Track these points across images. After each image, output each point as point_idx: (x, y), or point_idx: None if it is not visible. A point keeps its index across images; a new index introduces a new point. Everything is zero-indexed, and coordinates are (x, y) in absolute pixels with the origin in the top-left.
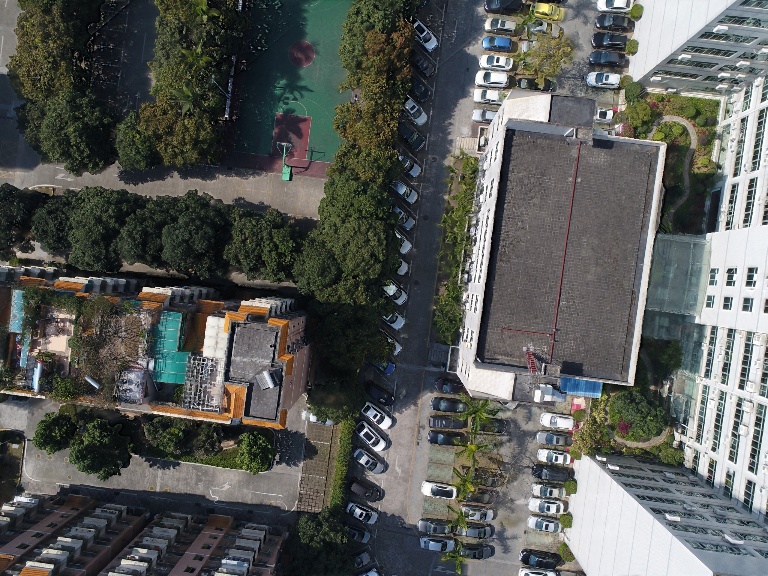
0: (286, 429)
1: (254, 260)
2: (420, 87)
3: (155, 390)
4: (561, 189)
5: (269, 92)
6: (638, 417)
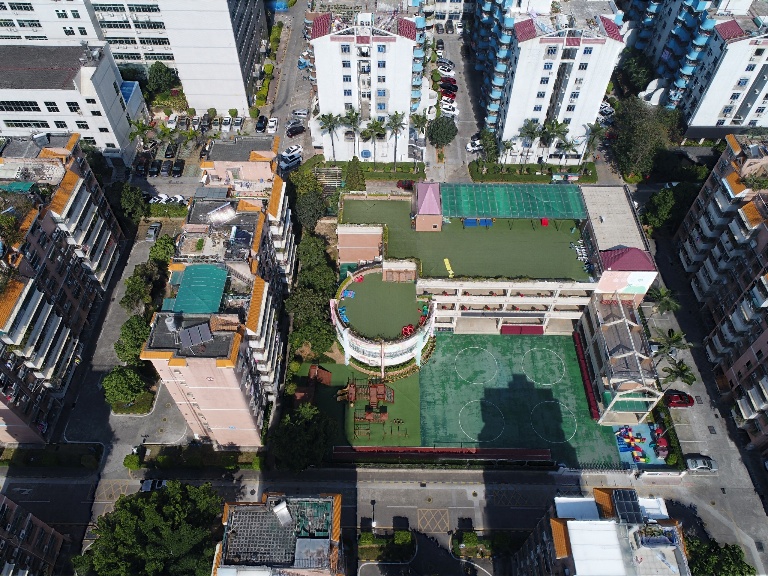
0: None
1: None
2: None
3: None
4: None
5: None
6: None
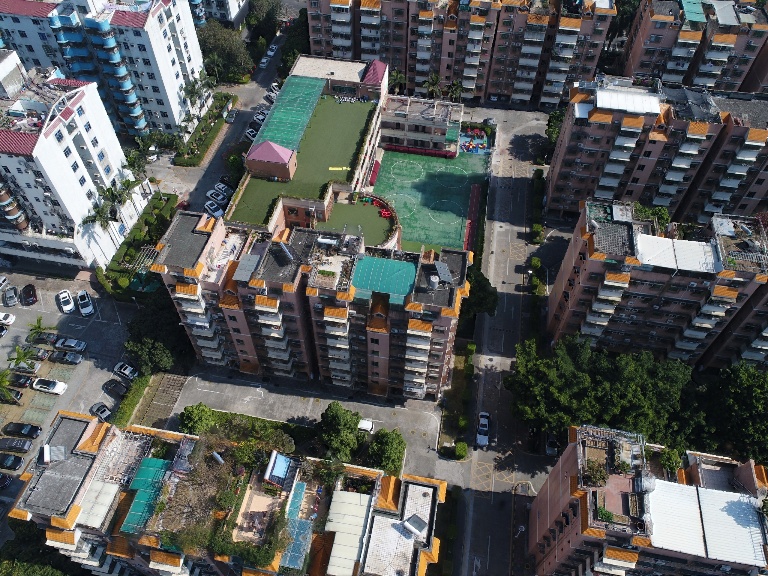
0: None
1: None
2: None
3: None
4: None
5: None
6: None
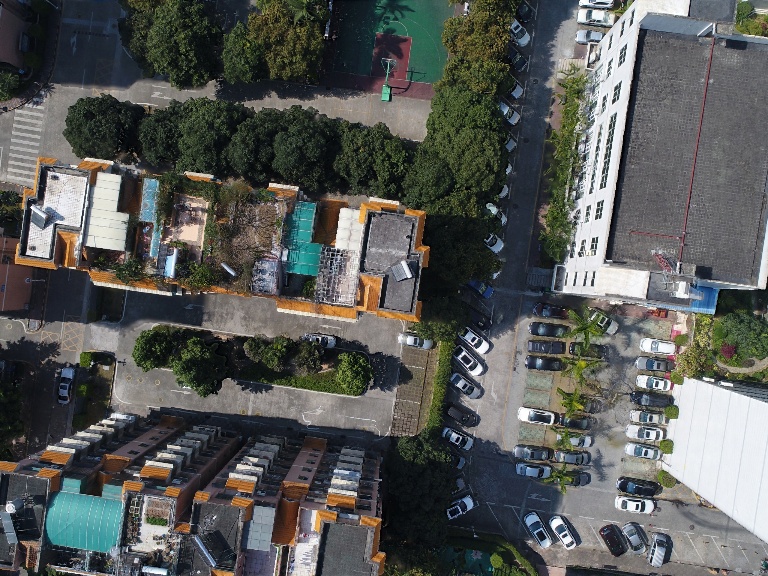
0: (381, 353)
1: (366, 170)
2: (524, 7)
3: (282, 286)
4: (693, 90)
5: (369, 11)
6: (752, 334)
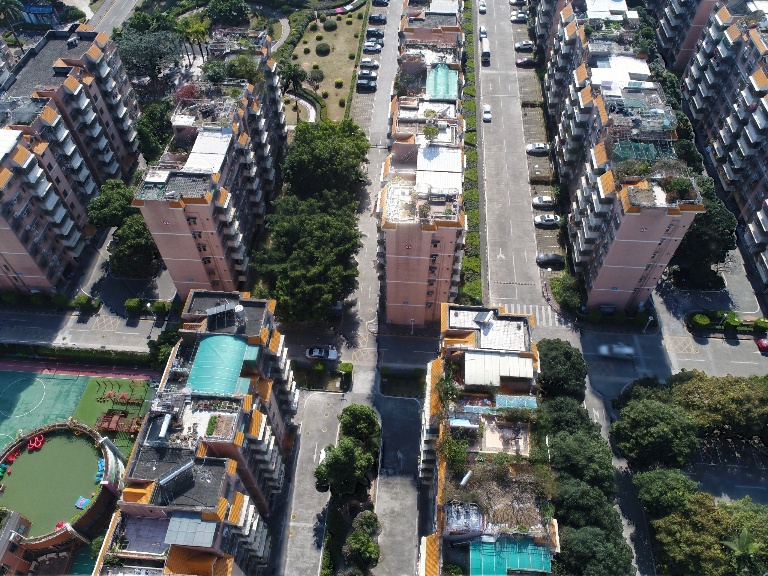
0: None
1: None
2: None
3: (451, 540)
4: None
5: None
6: None
